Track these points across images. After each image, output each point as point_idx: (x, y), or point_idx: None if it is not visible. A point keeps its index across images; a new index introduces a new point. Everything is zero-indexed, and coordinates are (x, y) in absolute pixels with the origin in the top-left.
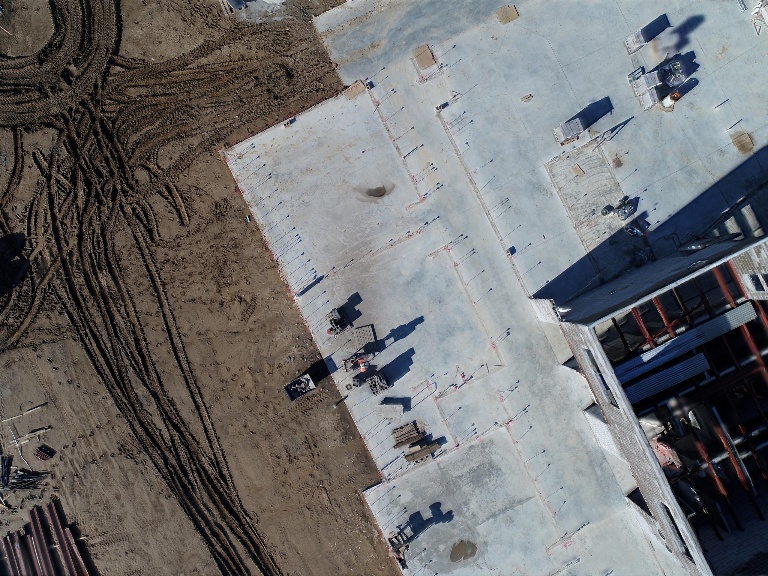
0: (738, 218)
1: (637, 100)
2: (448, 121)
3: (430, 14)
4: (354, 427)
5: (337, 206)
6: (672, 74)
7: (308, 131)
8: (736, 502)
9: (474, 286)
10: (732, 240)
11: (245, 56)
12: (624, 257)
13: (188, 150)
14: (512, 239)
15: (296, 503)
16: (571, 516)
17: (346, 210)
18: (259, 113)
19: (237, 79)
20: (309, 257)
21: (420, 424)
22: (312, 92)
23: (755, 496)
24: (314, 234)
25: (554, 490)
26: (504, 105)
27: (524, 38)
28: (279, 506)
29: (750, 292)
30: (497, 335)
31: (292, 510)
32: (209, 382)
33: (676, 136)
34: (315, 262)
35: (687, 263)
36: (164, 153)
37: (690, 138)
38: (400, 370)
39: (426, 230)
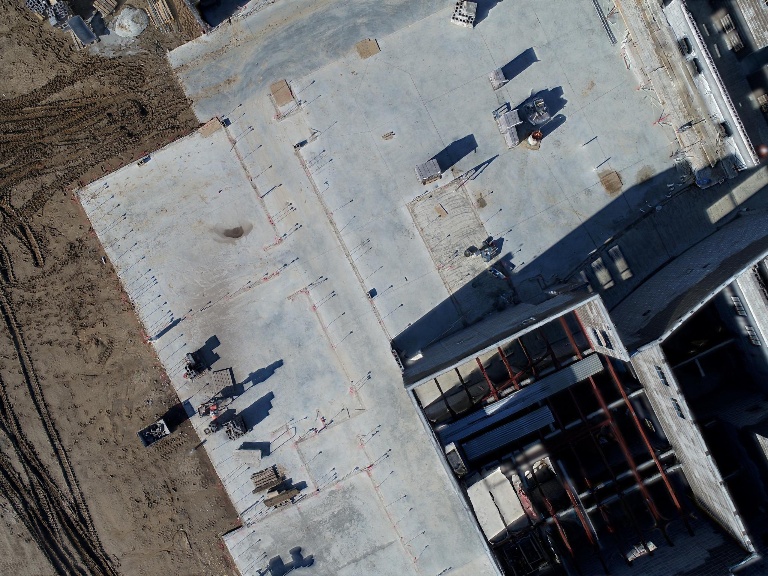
0: (605, 259)
1: (502, 138)
2: (307, 160)
3: (288, 48)
4: (213, 471)
5: (194, 247)
6: (536, 111)
7: (163, 170)
8: (584, 554)
9: (334, 329)
10: (599, 282)
11: (98, 92)
12: (488, 299)
13: (41, 189)
14: (373, 281)
15: (156, 547)
16: (433, 560)
17: (203, 251)
18: (114, 151)
19: (90, 116)
20: (165, 299)
21: (280, 468)
22: (167, 129)
23: (600, 550)
24: (170, 276)
25: (415, 535)
26: (365, 143)
27: (385, 73)
28: (139, 549)
29: (594, 344)
30: (358, 379)
31: (153, 553)
32: (67, 425)
33: (542, 175)
34: (172, 305)
35: (526, 316)
36: (17, 192)
37: (557, 177)
38: (259, 414)
39: (285, 272)
